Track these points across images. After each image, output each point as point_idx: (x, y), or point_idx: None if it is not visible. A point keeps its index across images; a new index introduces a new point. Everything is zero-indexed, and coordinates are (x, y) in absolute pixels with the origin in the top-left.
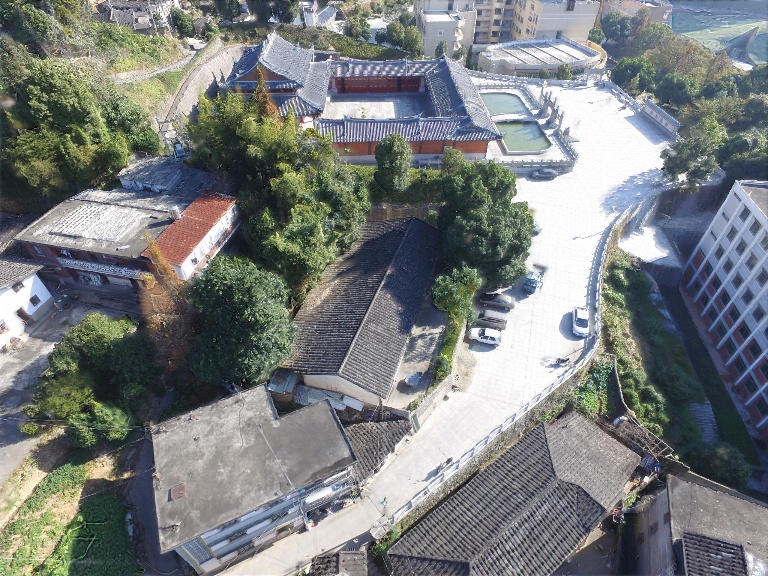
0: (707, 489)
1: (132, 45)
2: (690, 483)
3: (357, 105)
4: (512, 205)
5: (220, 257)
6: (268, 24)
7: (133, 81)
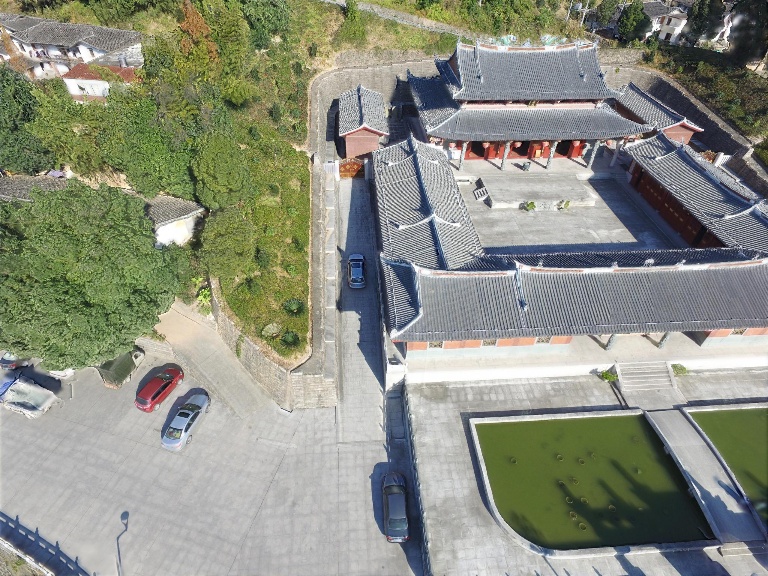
0: None
1: (473, 2)
2: None
3: (580, 198)
4: (35, 269)
5: None
6: (732, 65)
7: (409, 24)
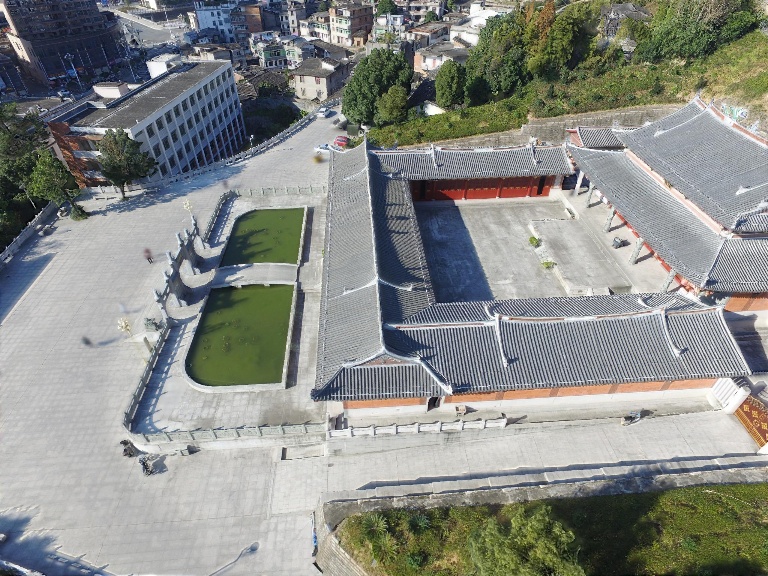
0: (316, 75)
1: None
2: (320, 76)
3: (567, 276)
4: None
5: (508, 14)
6: None
7: None
